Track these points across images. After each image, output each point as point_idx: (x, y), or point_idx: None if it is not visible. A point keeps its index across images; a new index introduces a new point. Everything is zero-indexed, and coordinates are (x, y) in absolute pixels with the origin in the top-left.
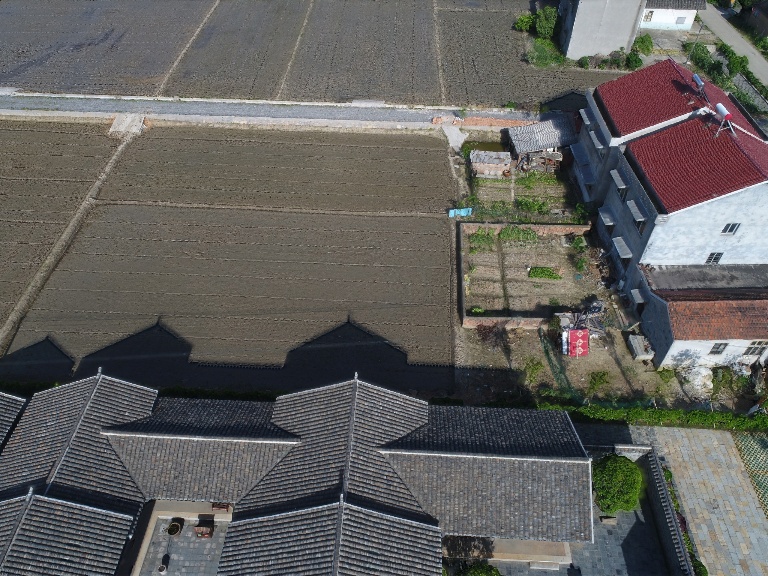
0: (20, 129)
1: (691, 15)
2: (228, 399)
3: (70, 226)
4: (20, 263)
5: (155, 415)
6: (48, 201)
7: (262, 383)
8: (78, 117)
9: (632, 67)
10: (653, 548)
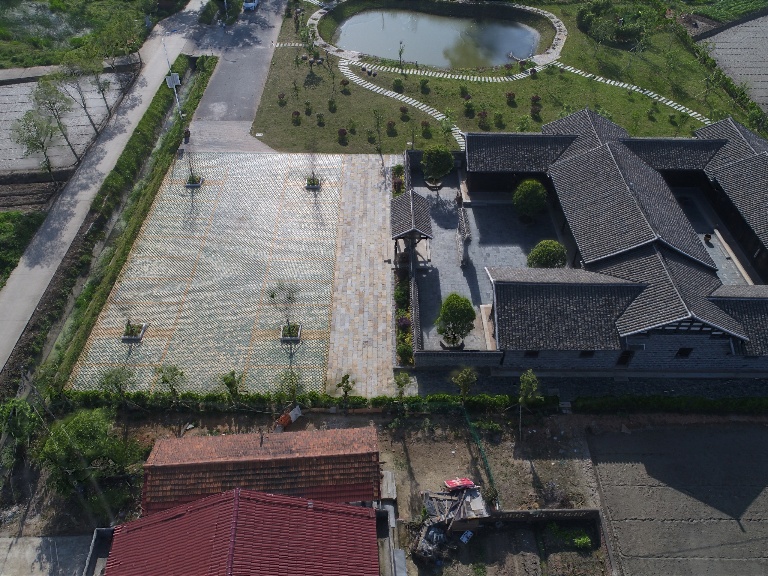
0: None
1: None
2: None
3: None
4: None
5: None
6: None
7: None
8: None
9: None
10: (421, 317)
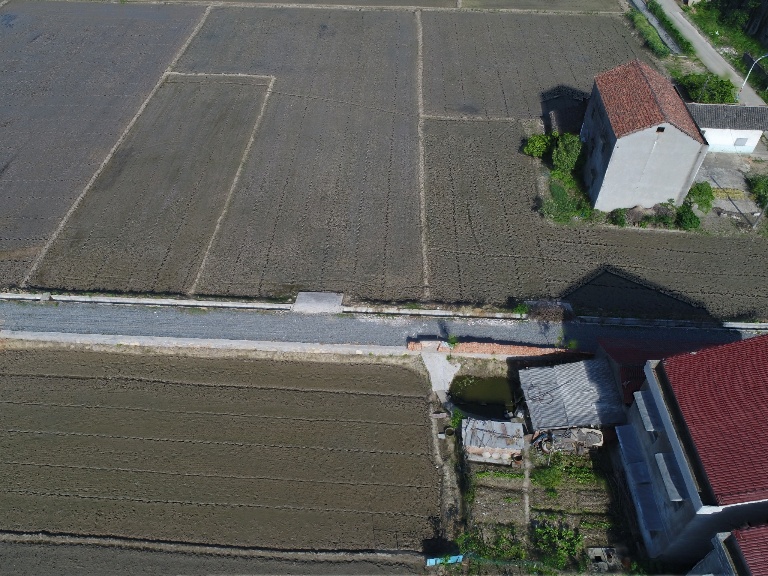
0: None
1: (755, 136)
2: None
3: None
4: None
5: None
6: None
7: None
8: None
9: (685, 228)
10: None
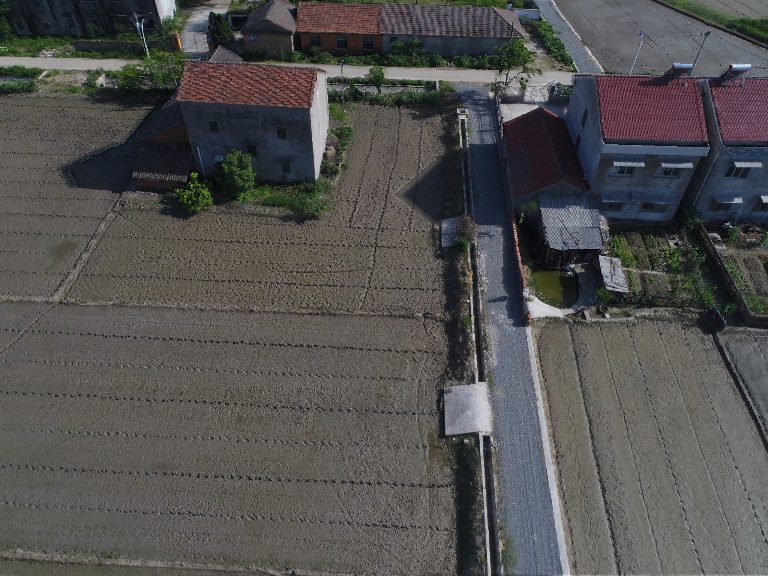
0: None
1: None
2: None
3: None
4: None
5: None
6: None
7: None
8: None
9: None
10: None
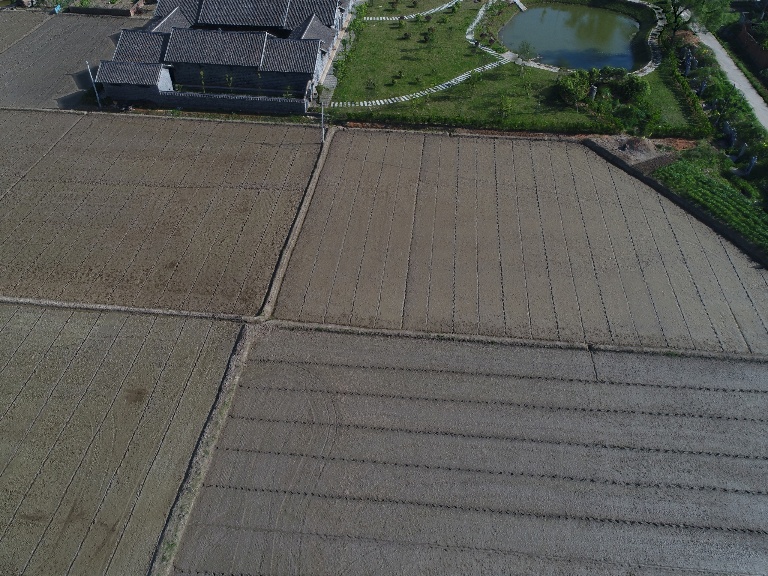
0: None
1: None
2: None
3: None
4: None
5: None
6: None
7: None
8: None
9: None
10: None
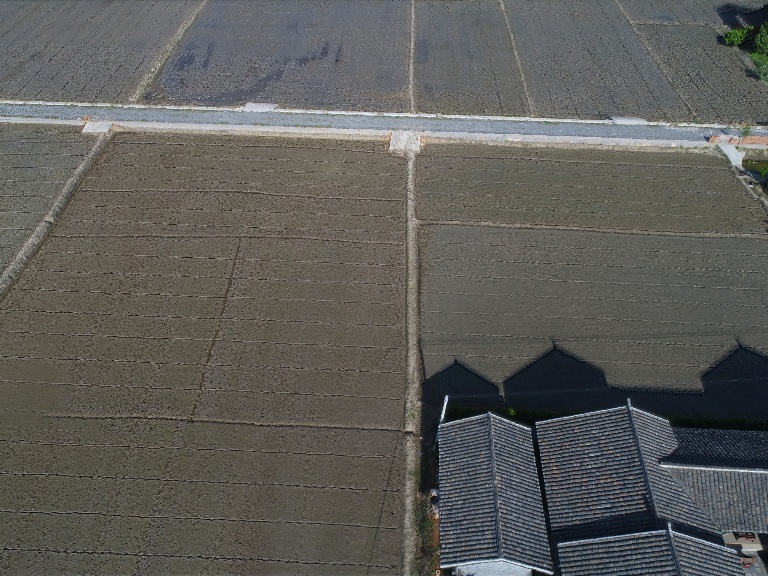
0: (299, 146)
1: None
2: (685, 426)
3: (411, 247)
4: (384, 285)
5: (681, 446)
6: (372, 221)
7: (694, 409)
8: (351, 134)
9: None
10: None
